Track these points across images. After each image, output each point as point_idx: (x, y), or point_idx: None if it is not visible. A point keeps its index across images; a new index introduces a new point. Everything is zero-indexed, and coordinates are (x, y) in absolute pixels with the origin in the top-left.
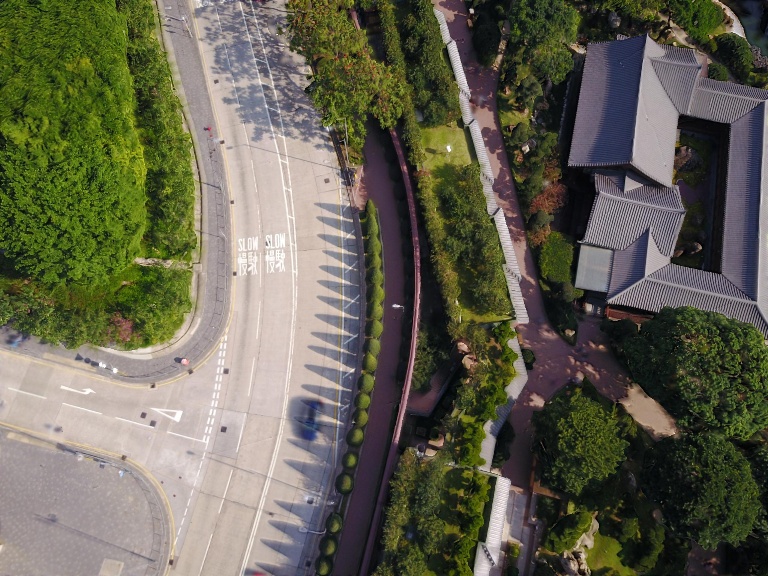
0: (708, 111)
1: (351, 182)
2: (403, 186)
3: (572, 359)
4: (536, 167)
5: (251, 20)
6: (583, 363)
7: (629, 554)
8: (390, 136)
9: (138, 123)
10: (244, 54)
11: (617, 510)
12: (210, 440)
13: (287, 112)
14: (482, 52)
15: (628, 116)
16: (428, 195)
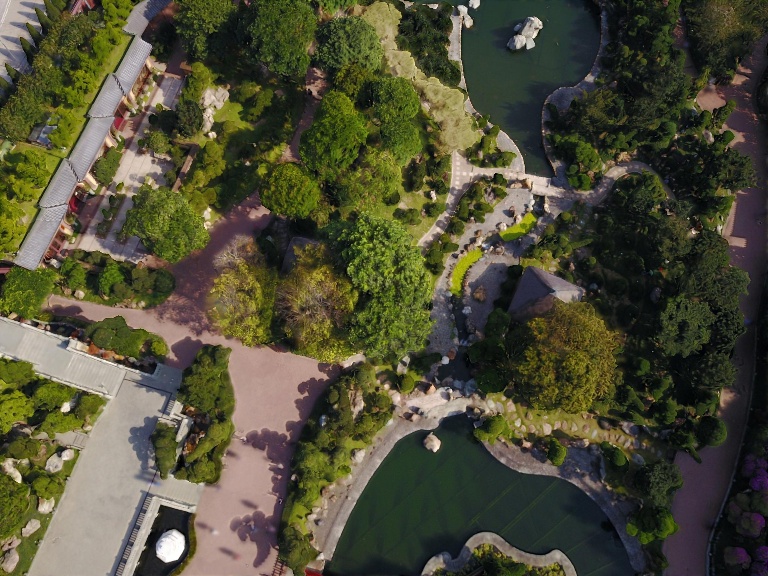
0: None
1: None
2: None
3: (246, 1)
4: None
5: None
6: None
7: None
8: None
9: None
10: None
11: None
12: None
13: None
14: None
15: None
16: None
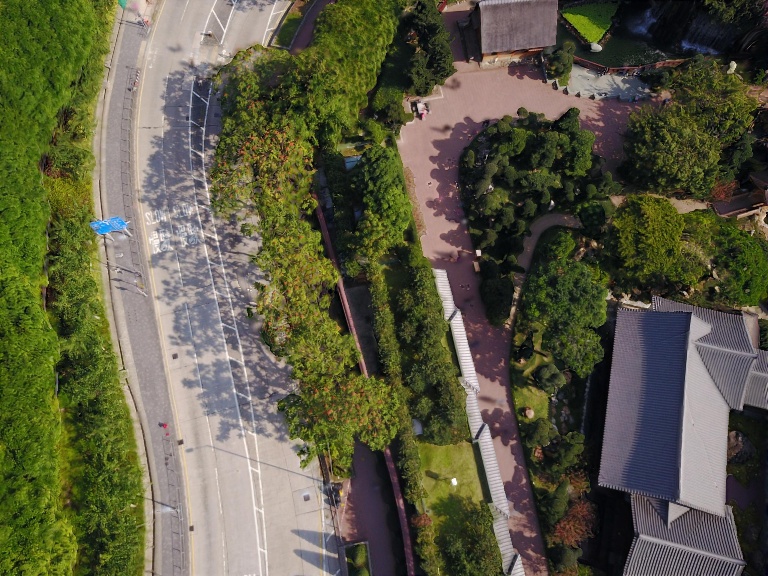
0: (763, 398)
1: (336, 506)
2: (399, 526)
3: None
4: (559, 476)
5: (218, 270)
6: None
7: None
8: (383, 454)
9: (76, 433)
10: (209, 317)
11: None
12: None
13: (259, 399)
14: (492, 313)
15: (671, 429)
16: (430, 553)
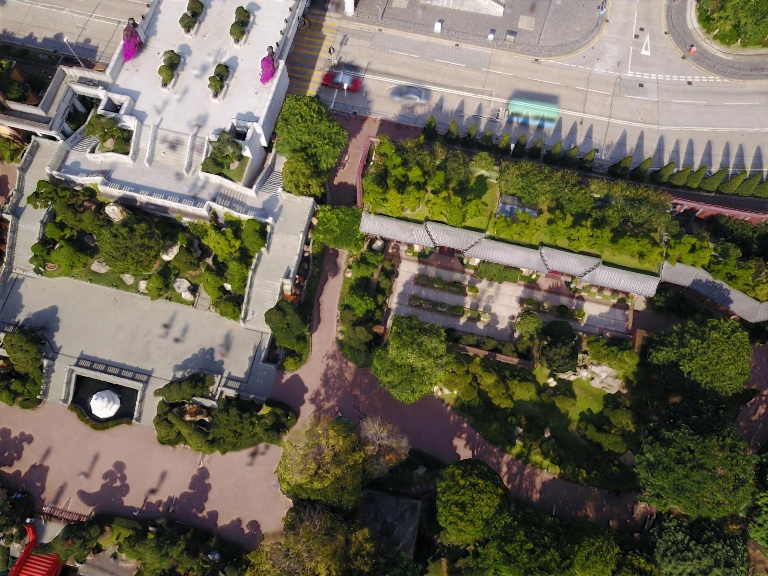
0: None
1: None
2: None
3: (766, 392)
4: None
5: None
6: (765, 404)
7: (591, 420)
8: None
9: None
10: None
11: (633, 409)
12: (631, 77)
13: None
14: None
15: None
16: None
